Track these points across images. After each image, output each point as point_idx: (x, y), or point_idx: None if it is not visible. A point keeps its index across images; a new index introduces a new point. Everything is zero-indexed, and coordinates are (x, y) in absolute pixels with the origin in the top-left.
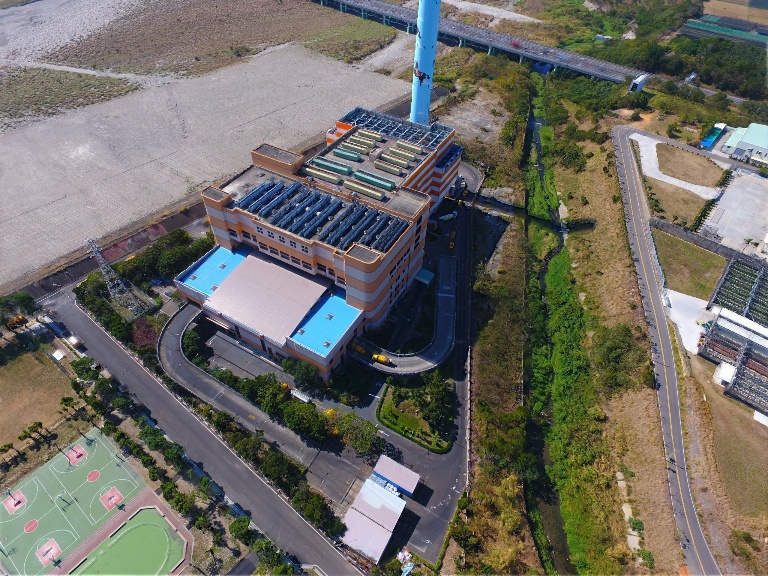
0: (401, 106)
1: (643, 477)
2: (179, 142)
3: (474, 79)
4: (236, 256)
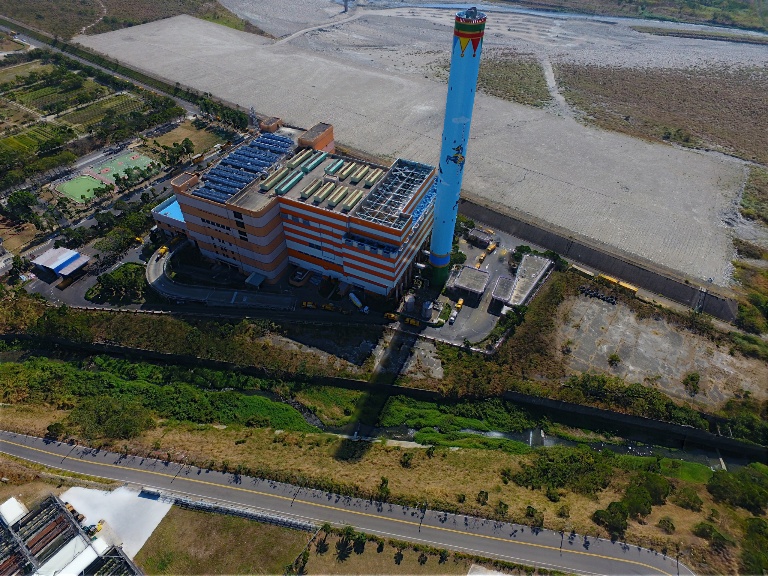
0: (615, 260)
1: None
2: None
3: None
4: None
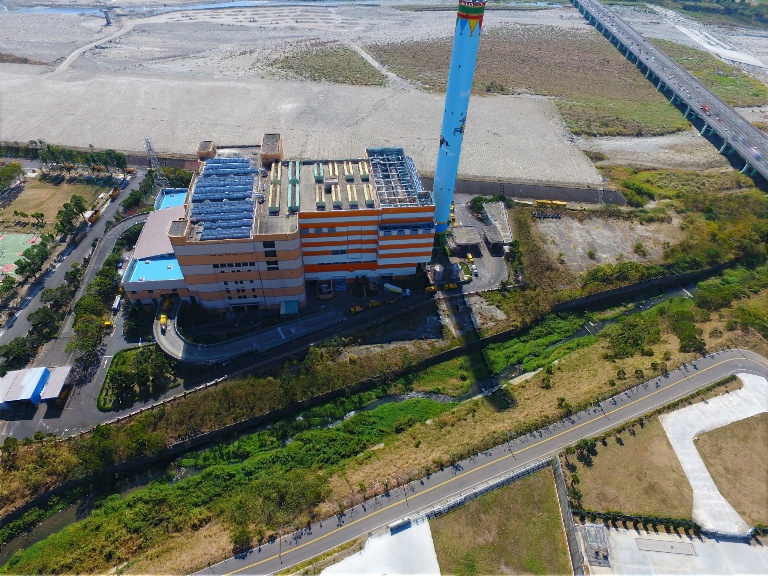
0: (538, 187)
1: None
2: (340, 128)
3: (685, 208)
4: None
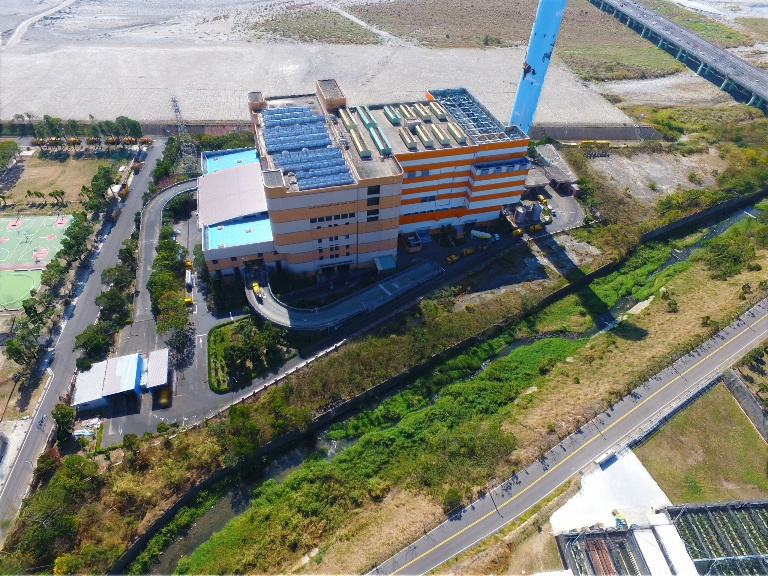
0: (578, 128)
1: (321, 571)
2: (354, 86)
3: (716, 138)
4: (255, 160)
